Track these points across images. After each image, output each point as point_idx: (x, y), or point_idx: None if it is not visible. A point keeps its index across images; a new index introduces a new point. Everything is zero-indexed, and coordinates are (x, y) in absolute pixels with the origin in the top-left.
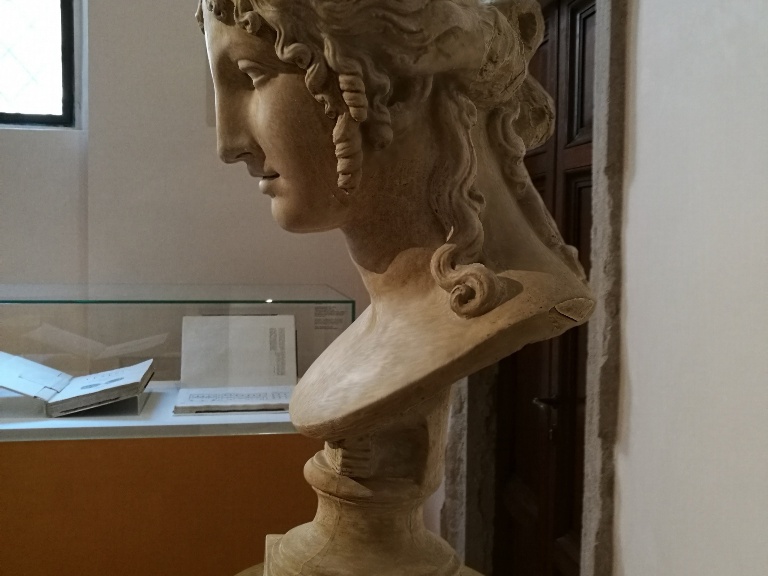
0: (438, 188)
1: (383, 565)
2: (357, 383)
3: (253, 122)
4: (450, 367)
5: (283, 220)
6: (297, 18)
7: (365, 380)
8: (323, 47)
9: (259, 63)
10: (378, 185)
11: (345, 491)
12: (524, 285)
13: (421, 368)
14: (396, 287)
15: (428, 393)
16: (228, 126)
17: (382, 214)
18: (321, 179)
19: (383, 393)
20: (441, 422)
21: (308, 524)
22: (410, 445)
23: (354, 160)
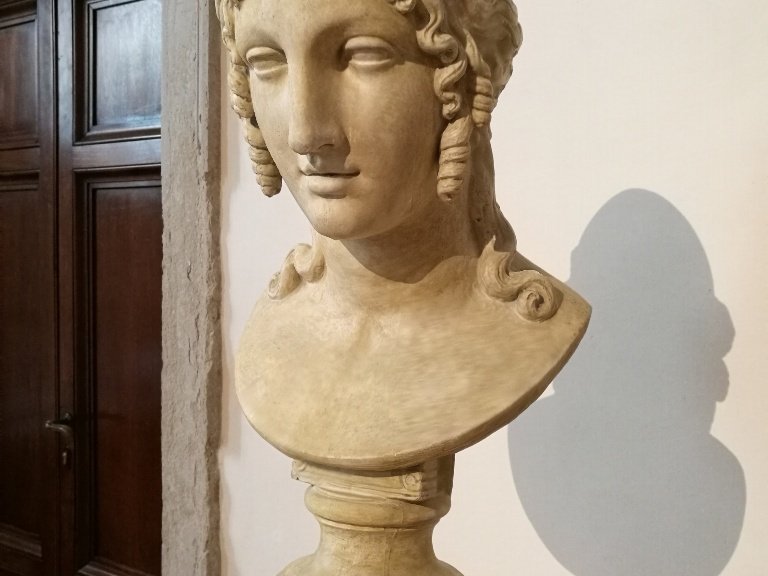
0: (485, 197)
1: None
2: (450, 398)
3: (348, 109)
4: (556, 367)
5: (351, 225)
6: (445, 6)
7: (460, 394)
8: (465, 44)
9: (393, 45)
10: None
11: (413, 518)
12: (559, 289)
13: (533, 372)
14: (429, 297)
15: (537, 395)
16: (317, 110)
17: (434, 221)
18: (412, 182)
19: (507, 402)
20: None
21: (321, 574)
22: None
23: (467, 165)
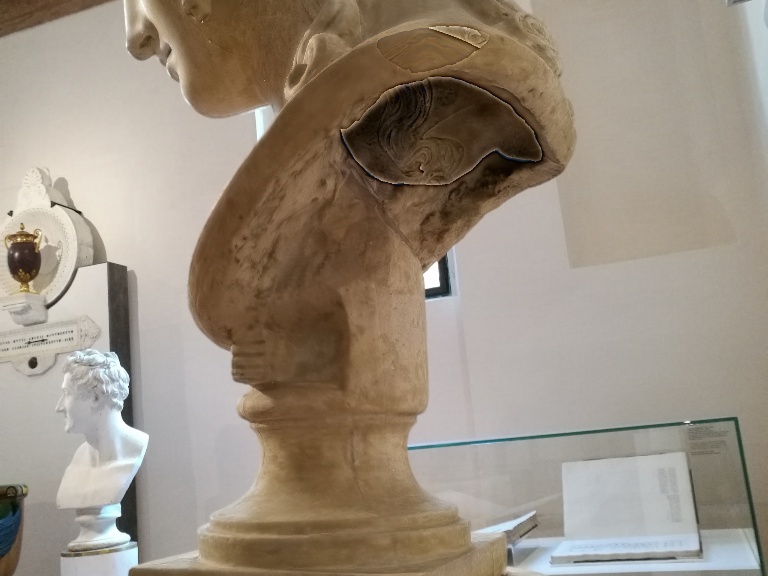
0: None
1: (291, 507)
2: None
3: None
4: (254, 157)
5: (185, 97)
6: None
7: None
8: None
9: None
10: (253, 12)
11: (249, 406)
12: None
13: None
14: None
15: (243, 206)
16: (128, 16)
17: (265, 46)
18: (189, 24)
19: None
20: (374, 301)
21: None
22: (333, 338)
23: None
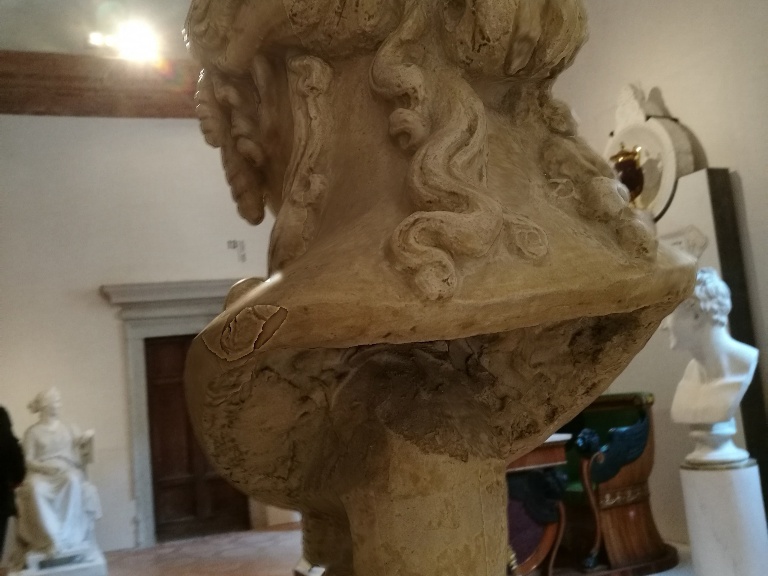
0: None
1: None
2: None
3: None
4: None
5: None
6: None
7: None
8: None
9: None
10: None
11: None
12: None
13: None
14: None
15: (205, 451)
16: None
17: None
18: None
19: None
20: (374, 509)
21: None
22: None
23: None
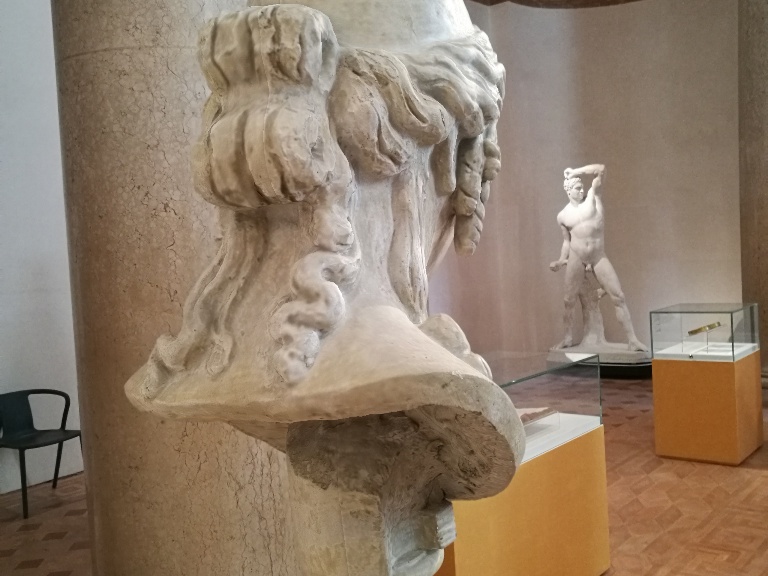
0: None
1: None
2: None
3: None
4: None
5: None
6: None
7: None
8: None
9: None
10: None
11: None
12: None
13: None
14: None
15: None
16: None
17: None
18: None
19: None
20: None
21: None
22: None
23: None
